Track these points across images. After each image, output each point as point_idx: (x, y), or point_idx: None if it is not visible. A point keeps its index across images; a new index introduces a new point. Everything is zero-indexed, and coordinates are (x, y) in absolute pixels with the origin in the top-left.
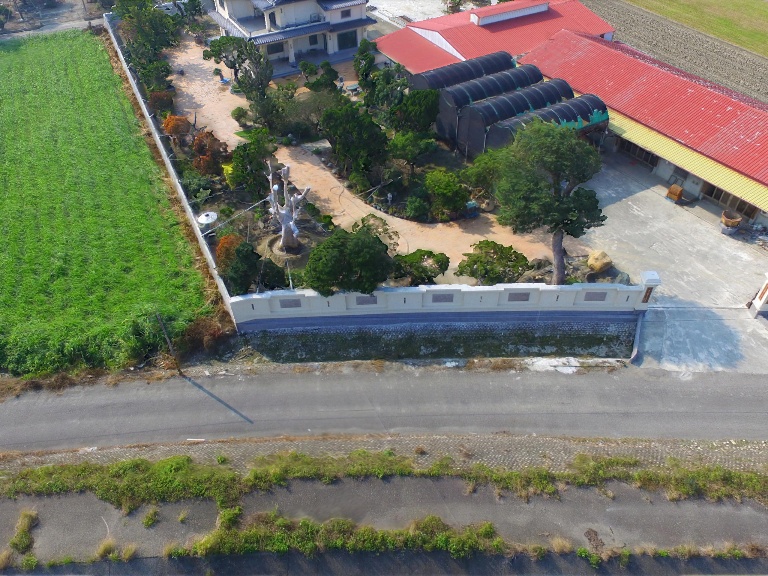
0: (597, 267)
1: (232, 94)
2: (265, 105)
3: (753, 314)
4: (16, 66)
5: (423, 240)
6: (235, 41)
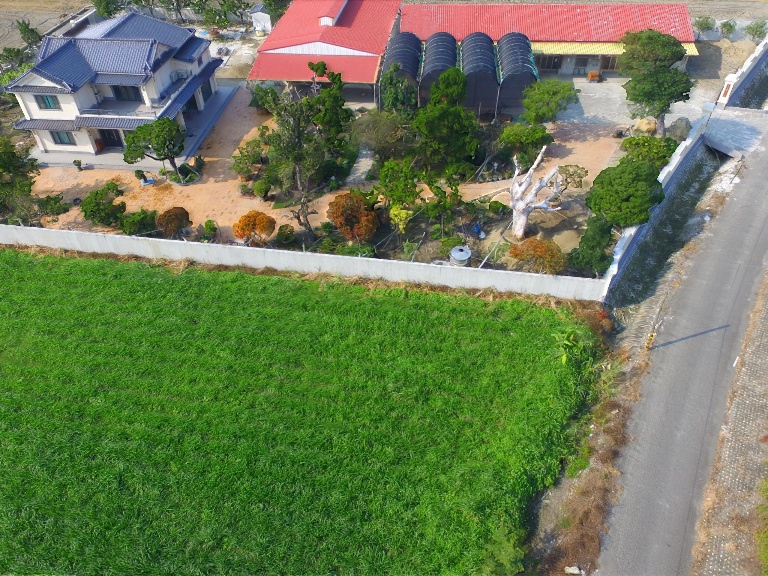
0: (654, 128)
1: (187, 186)
2: None
3: (722, 108)
4: None
5: None
6: (168, 123)
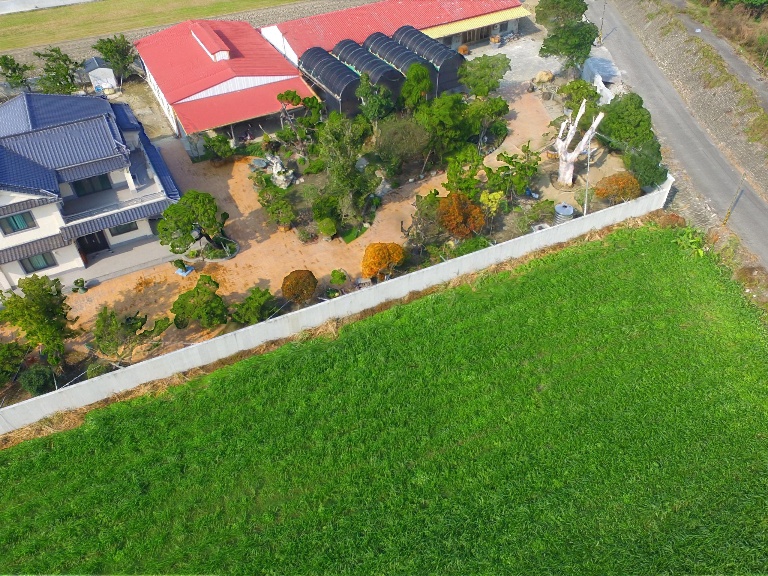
0: None
1: (235, 257)
2: None
3: None
4: None
5: (530, 134)
6: (201, 195)
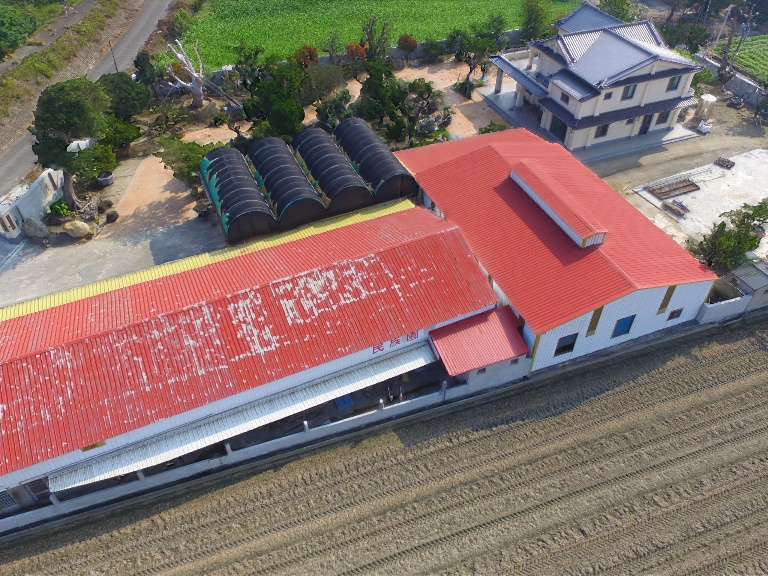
0: None
1: None
2: None
3: None
4: (520, 5)
5: None
6: (473, 44)
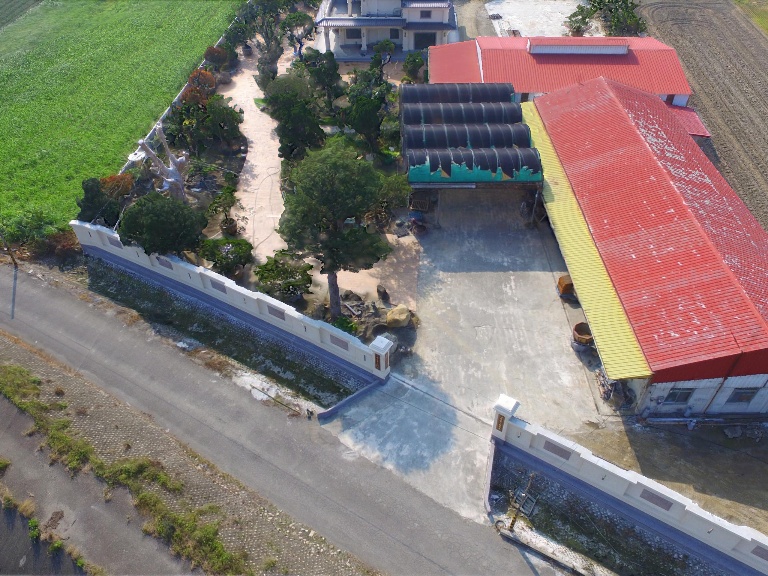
0: (387, 320)
1: (290, 66)
2: (265, 78)
3: None
4: (175, 5)
5: None
6: (301, 18)
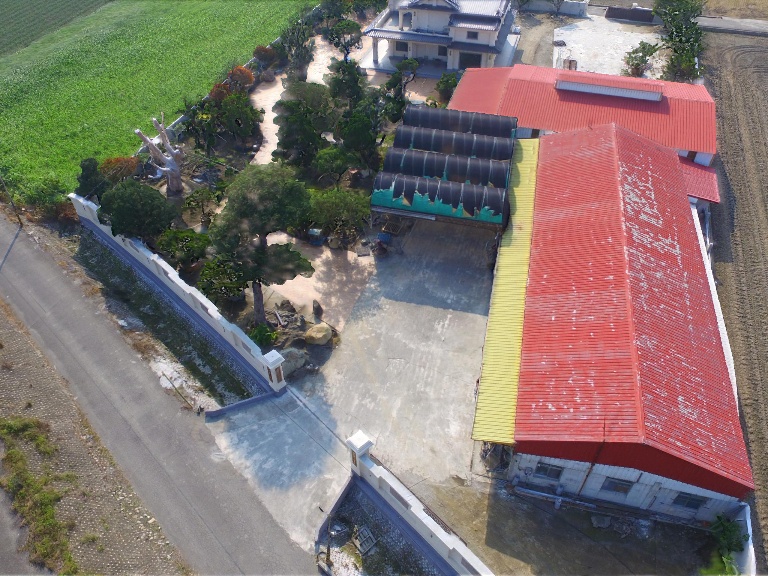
0: None
1: None
2: (290, 82)
3: None
4: None
5: None
6: (348, 26)
